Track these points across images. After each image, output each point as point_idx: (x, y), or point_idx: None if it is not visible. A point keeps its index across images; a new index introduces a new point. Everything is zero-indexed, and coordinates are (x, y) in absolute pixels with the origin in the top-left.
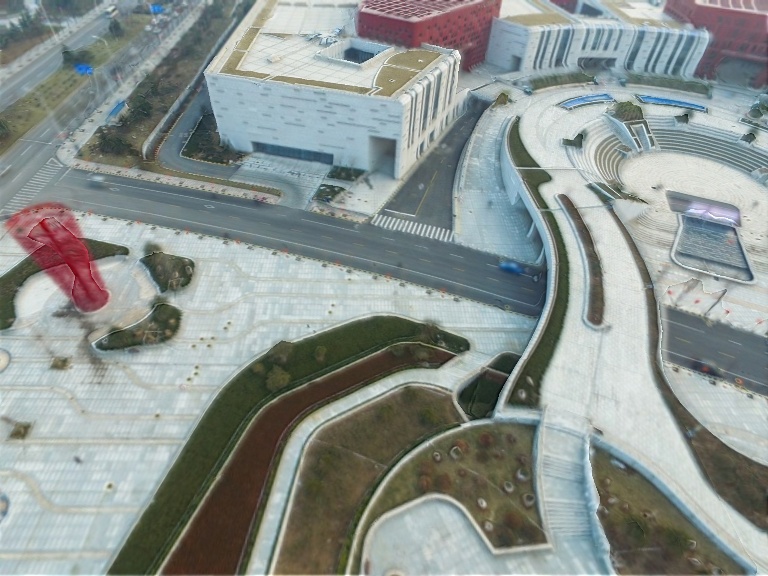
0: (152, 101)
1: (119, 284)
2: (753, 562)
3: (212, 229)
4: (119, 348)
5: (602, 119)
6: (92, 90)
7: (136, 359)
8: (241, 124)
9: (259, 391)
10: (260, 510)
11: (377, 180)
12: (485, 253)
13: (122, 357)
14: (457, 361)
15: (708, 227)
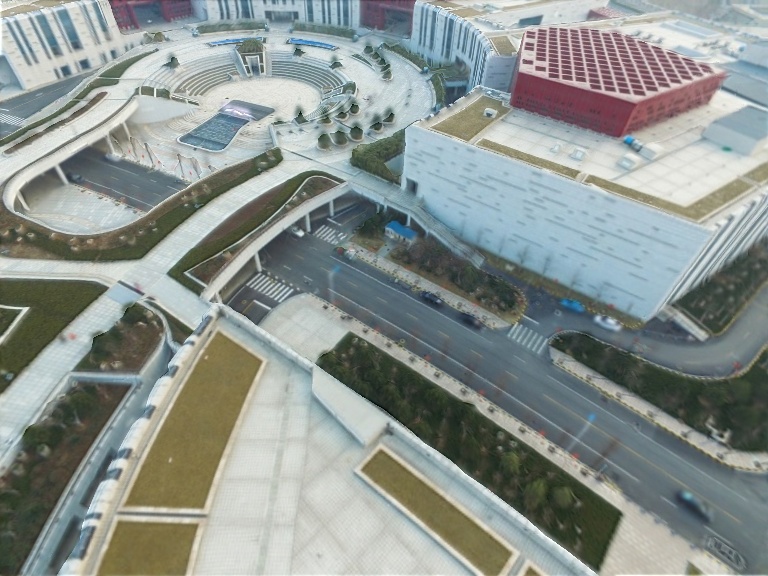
0: None
1: None
2: None
3: None
4: None
5: (229, 52)
6: None
7: None
8: None
9: None
10: None
11: (8, 90)
12: None
13: None
14: None
15: (229, 120)
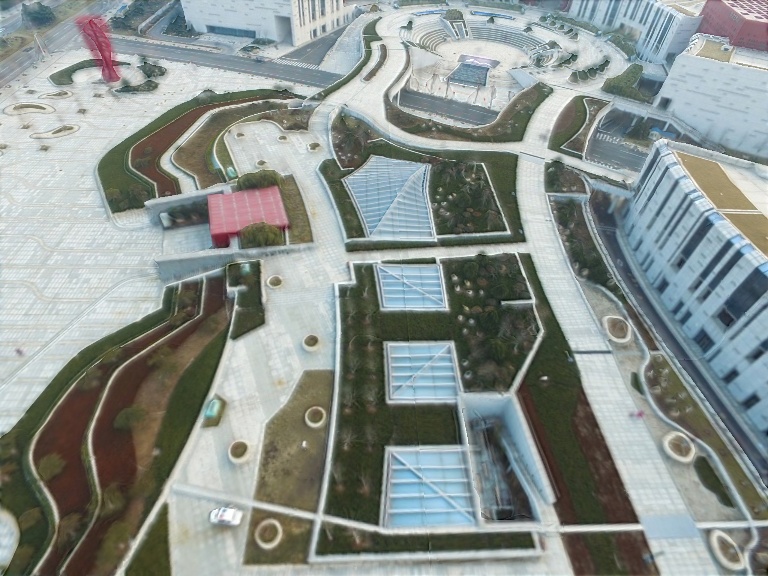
0: (144, 8)
1: (126, 75)
2: (389, 133)
3: (178, 60)
4: (127, 92)
5: (437, 20)
6: (105, 1)
7: (135, 97)
8: (199, 12)
9: (195, 104)
10: (190, 126)
11: (282, 46)
12: (334, 74)
13: (128, 95)
14: (297, 100)
15: (474, 68)
